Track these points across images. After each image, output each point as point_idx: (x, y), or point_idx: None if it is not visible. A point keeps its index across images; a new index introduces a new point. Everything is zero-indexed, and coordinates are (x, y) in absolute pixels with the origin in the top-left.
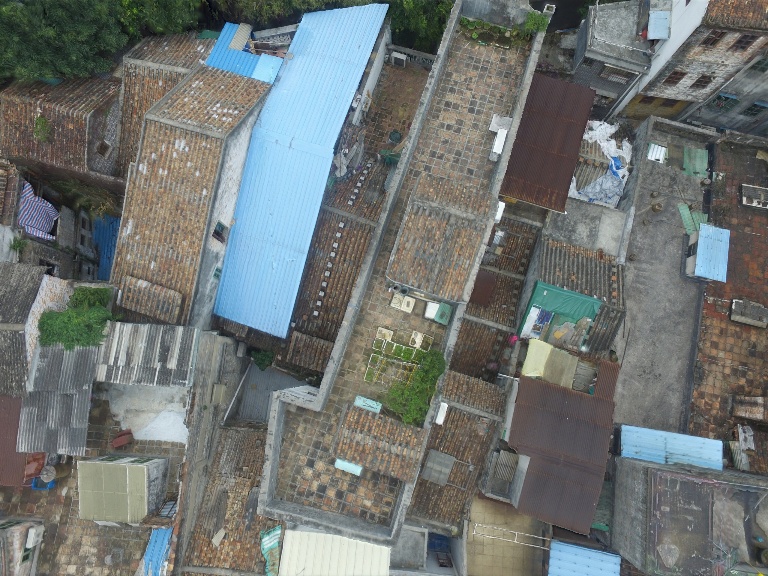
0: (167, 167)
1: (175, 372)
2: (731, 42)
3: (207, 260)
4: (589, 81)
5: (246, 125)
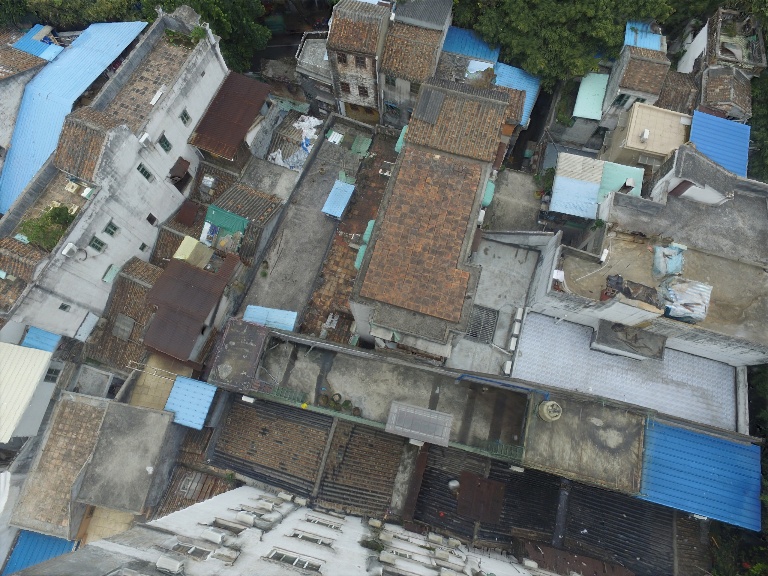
0: None
1: None
2: (353, 61)
3: None
4: (314, 91)
5: (17, 81)
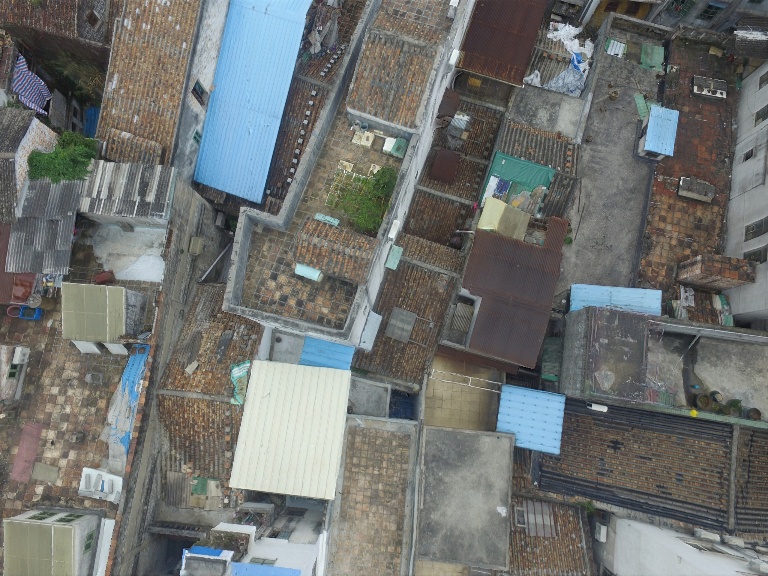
0: (150, 22)
1: (153, 205)
2: None
3: (187, 116)
4: None
5: None
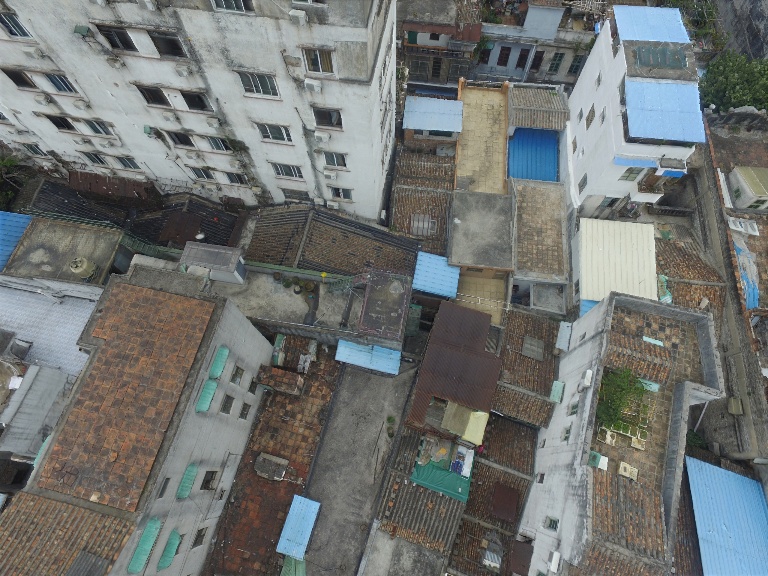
0: None
1: None
2: None
3: None
4: None
5: None
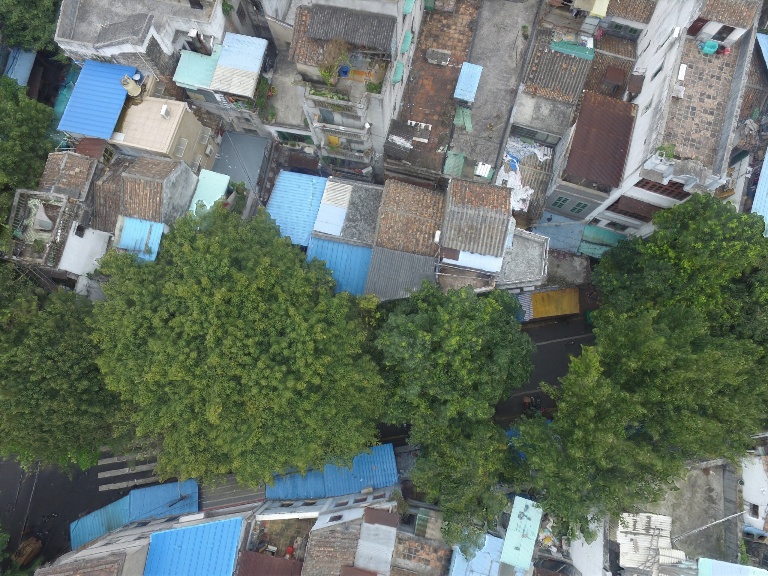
0: None
1: None
2: None
3: None
4: None
5: None
